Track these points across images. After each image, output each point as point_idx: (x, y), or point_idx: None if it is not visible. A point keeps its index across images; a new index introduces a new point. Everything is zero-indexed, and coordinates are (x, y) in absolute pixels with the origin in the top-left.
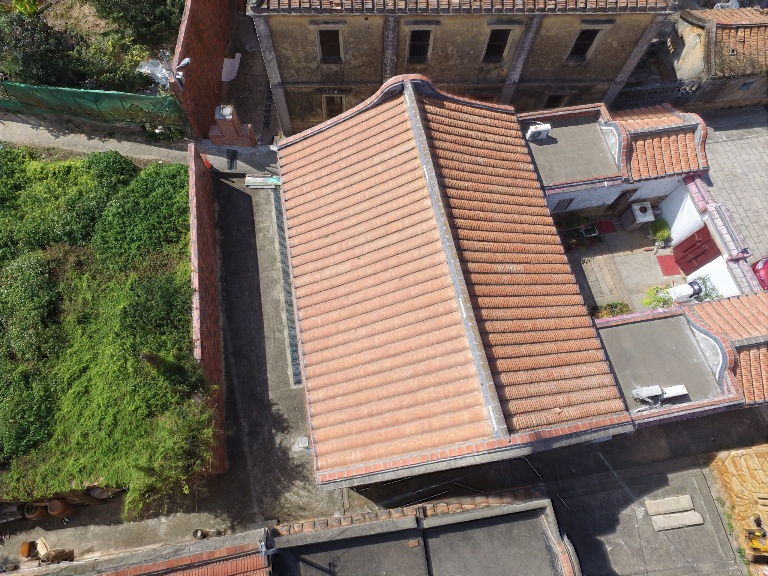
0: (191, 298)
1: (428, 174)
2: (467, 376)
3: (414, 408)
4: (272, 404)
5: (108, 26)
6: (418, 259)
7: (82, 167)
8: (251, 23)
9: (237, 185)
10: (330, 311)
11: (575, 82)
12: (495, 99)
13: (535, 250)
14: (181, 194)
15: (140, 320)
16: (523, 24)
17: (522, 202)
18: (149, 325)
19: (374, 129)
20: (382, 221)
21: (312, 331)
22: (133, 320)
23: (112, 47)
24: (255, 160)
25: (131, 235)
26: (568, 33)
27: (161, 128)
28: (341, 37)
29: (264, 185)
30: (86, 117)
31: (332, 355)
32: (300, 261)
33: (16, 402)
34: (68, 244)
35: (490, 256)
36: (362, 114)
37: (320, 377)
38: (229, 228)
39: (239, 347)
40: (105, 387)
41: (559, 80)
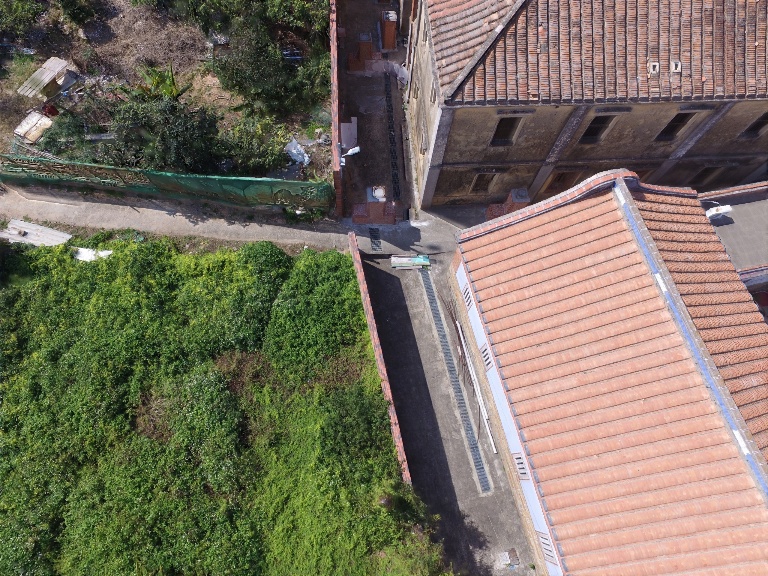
0: (387, 412)
1: (667, 285)
2: (758, 520)
3: (695, 553)
4: (464, 516)
5: (233, 98)
6: (664, 379)
7: (238, 262)
8: (361, 83)
9: (383, 266)
10: (561, 432)
11: (738, 155)
12: (650, 171)
13: (762, 355)
14: (349, 289)
15: (341, 442)
16: (714, 108)
17: (734, 299)
18: (352, 447)
19: (579, 227)
20: (609, 332)
21: (543, 455)
22: (334, 443)
23: (260, 130)
24: (398, 238)
25: (307, 340)
26: (753, 114)
27: (302, 209)
28: (522, 123)
29: (411, 266)
30: (226, 201)
31: (575, 484)
32: (512, 373)
33: (227, 548)
34: (238, 352)
35: (734, 370)
36: (560, 209)
37: (564, 509)
38: (382, 315)
39: (417, 451)
40: (314, 521)
41: (722, 154)
